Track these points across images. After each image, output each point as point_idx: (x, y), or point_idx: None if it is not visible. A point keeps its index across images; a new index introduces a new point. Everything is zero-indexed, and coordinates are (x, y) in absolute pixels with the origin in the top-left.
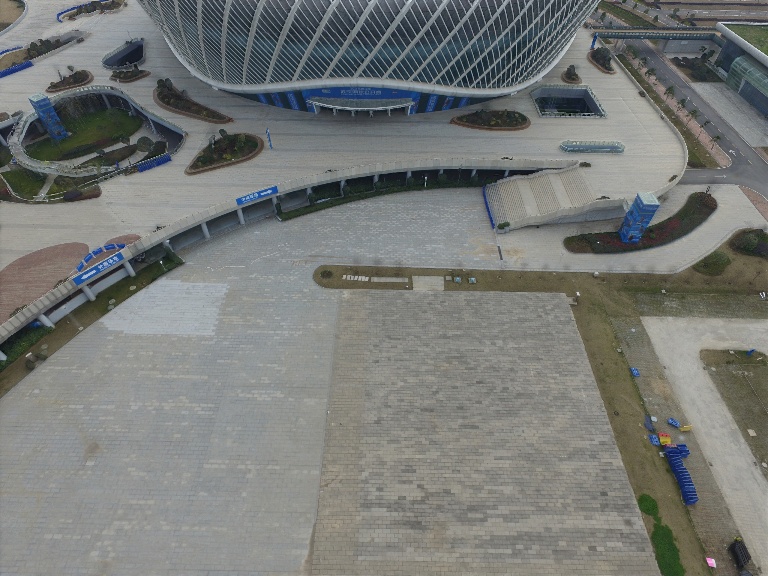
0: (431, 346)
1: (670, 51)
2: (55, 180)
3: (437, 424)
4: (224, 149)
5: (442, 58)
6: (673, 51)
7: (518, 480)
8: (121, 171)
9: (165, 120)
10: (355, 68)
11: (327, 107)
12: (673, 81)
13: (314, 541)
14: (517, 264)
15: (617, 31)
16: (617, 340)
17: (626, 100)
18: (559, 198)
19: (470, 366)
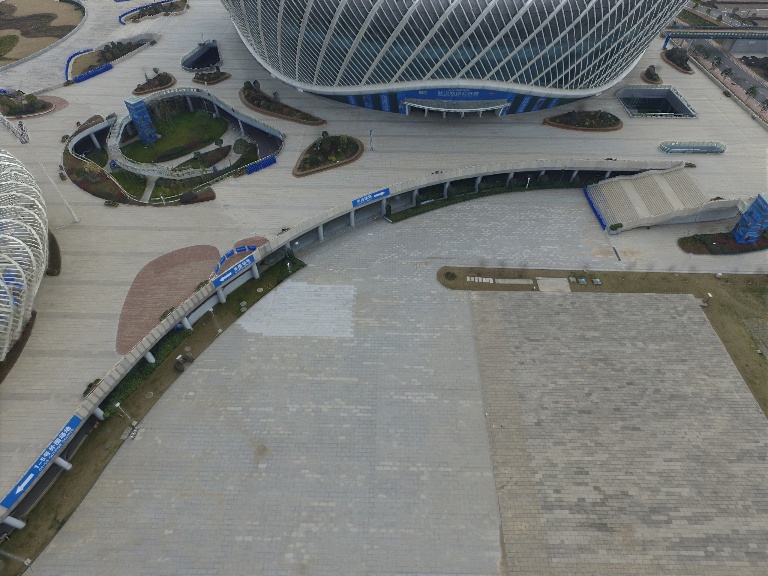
0: (572, 348)
1: (737, 51)
2: (157, 182)
3: (598, 426)
4: (328, 151)
5: (546, 59)
6: (740, 51)
7: (693, 482)
8: (220, 173)
9: (260, 122)
10: (459, 69)
11: (423, 108)
12: (747, 81)
13: (504, 543)
14: (637, 265)
15: (684, 31)
16: (754, 341)
17: (712, 100)
18: (669, 199)
19: (616, 368)
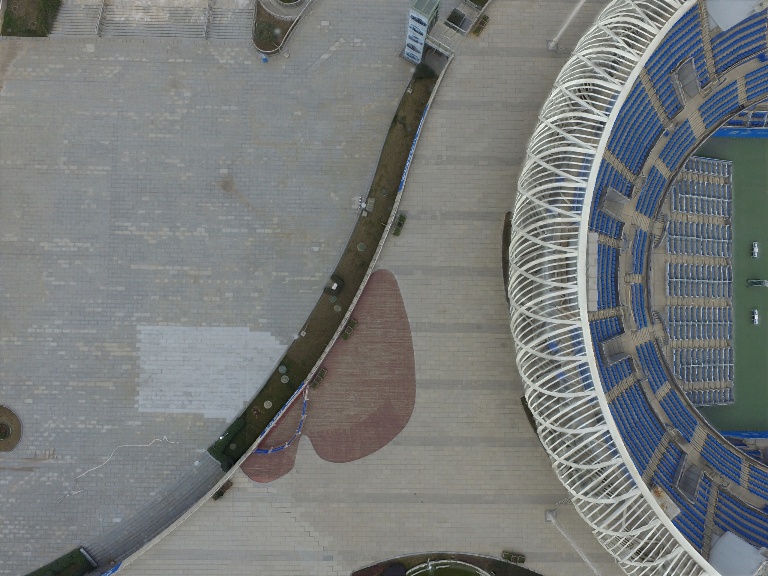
0: None
1: None
2: None
3: None
4: None
5: None
6: None
7: None
8: None
9: None
10: None
11: None
12: None
13: None
14: None
15: None
16: None
17: None
18: None
19: None
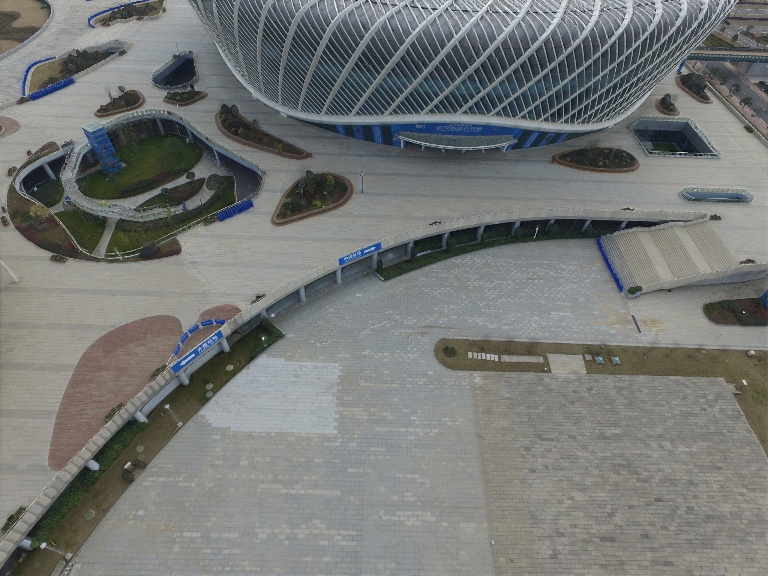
0: (591, 450)
1: (753, 74)
2: (117, 225)
3: (624, 559)
4: (313, 194)
5: (559, 95)
6: (756, 74)
7: None
8: (191, 214)
9: (237, 155)
10: (461, 105)
11: (420, 144)
12: (766, 110)
13: None
14: (659, 338)
15: (698, 52)
16: None
17: (734, 136)
18: (694, 258)
19: (642, 477)
